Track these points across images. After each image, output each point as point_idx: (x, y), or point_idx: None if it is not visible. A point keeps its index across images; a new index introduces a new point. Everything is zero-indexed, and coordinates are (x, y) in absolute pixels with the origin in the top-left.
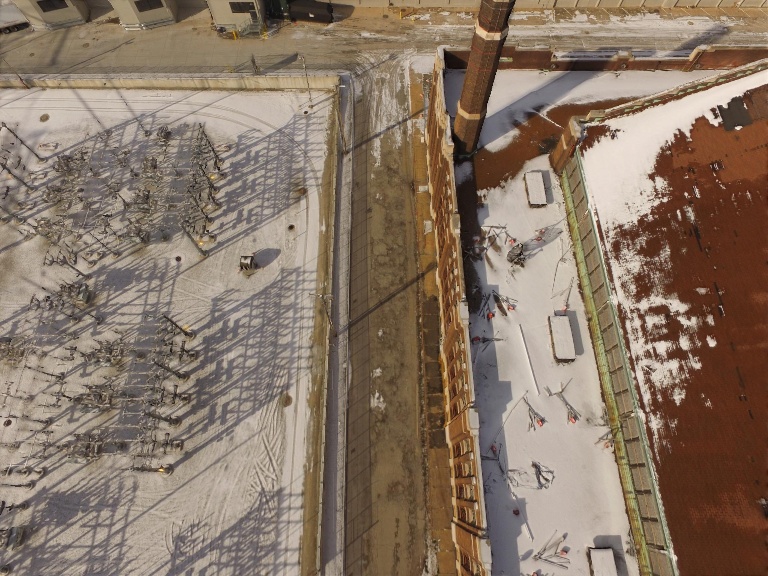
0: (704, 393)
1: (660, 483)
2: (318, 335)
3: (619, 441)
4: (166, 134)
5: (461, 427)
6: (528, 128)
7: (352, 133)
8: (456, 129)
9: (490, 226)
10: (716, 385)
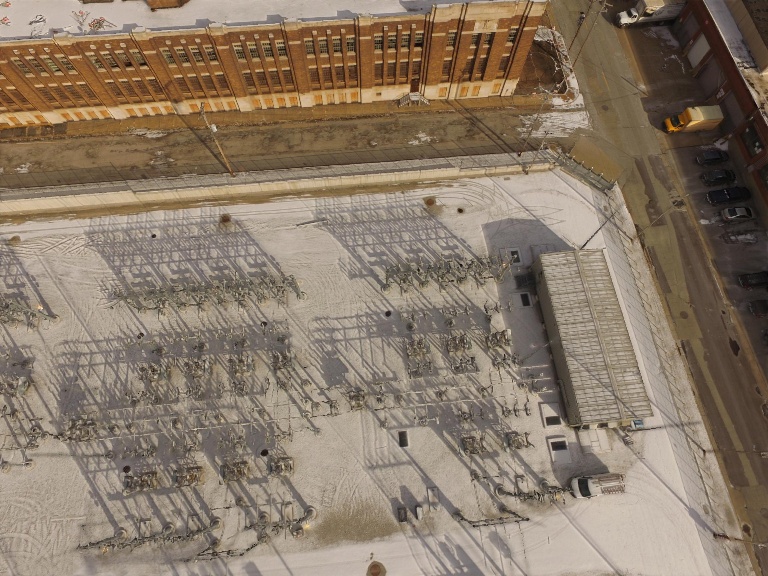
0: None
1: None
2: None
3: None
4: None
5: (6, 67)
6: None
7: None
8: None
9: None
10: None
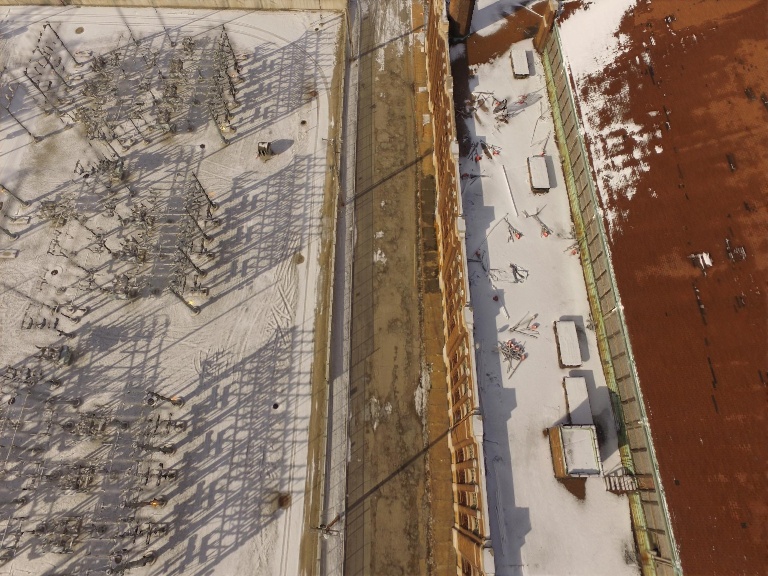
0: (651, 188)
1: (613, 257)
2: (327, 208)
3: (584, 248)
4: (190, 44)
5: (451, 244)
6: (515, 18)
7: (359, 44)
8: (451, 10)
9: (479, 92)
10: (661, 180)
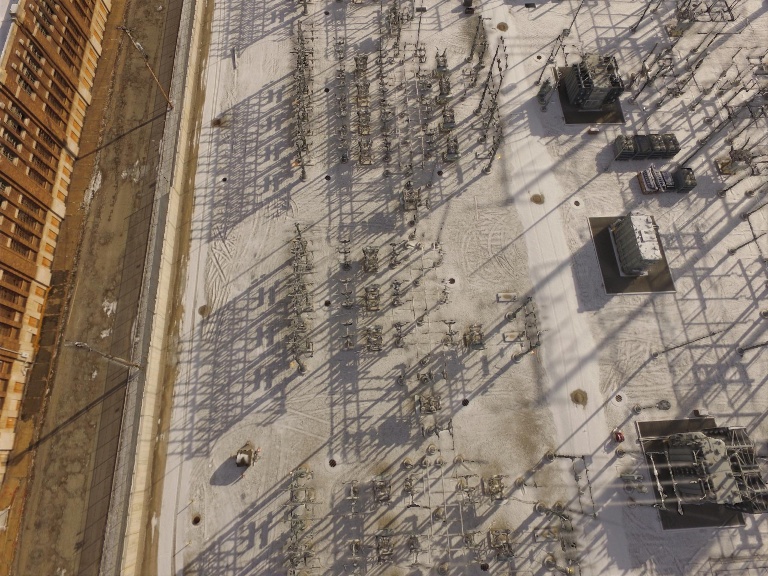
0: None
1: None
2: (170, 377)
3: None
4: None
5: None
6: None
7: None
8: None
9: None
10: None
